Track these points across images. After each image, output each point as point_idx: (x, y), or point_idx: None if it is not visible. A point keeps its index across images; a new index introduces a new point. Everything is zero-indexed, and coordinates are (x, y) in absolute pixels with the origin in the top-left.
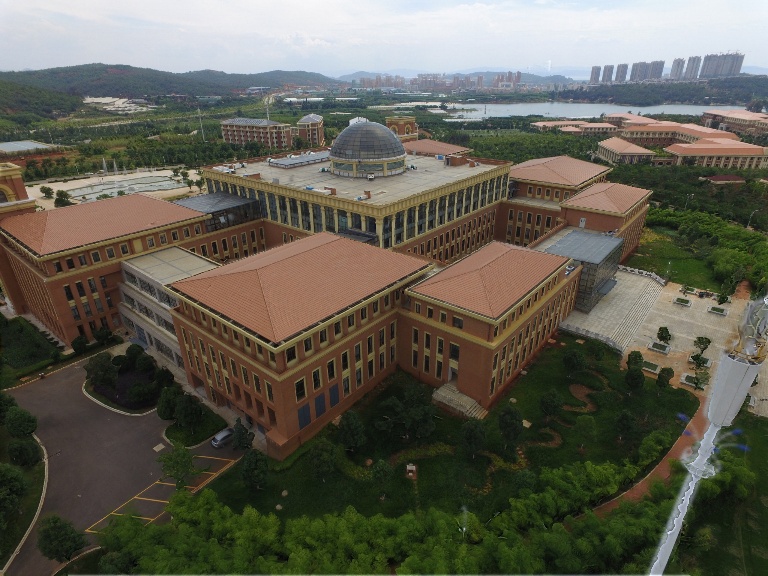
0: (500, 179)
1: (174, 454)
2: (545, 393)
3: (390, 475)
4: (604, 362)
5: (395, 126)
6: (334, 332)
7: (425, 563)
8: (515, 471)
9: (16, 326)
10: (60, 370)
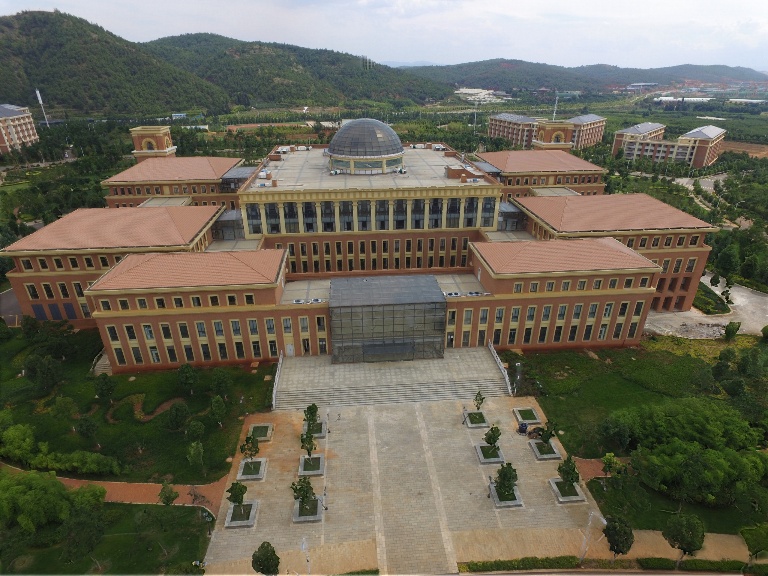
0: (477, 202)
1: None
2: None
3: None
4: (243, 403)
5: (542, 131)
6: (71, 264)
7: None
8: (34, 411)
9: None
10: None
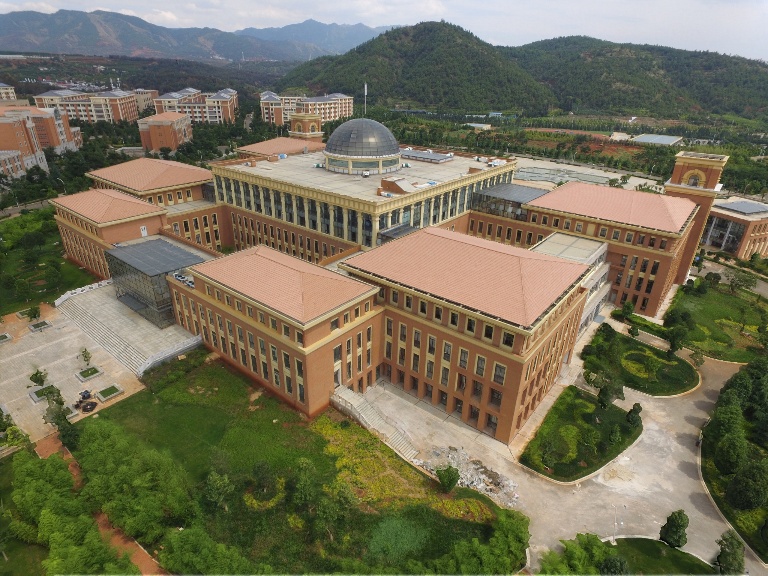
0: None
1: None
2: None
3: None
4: (56, 297)
5: None
6: None
7: None
8: None
9: None
10: None
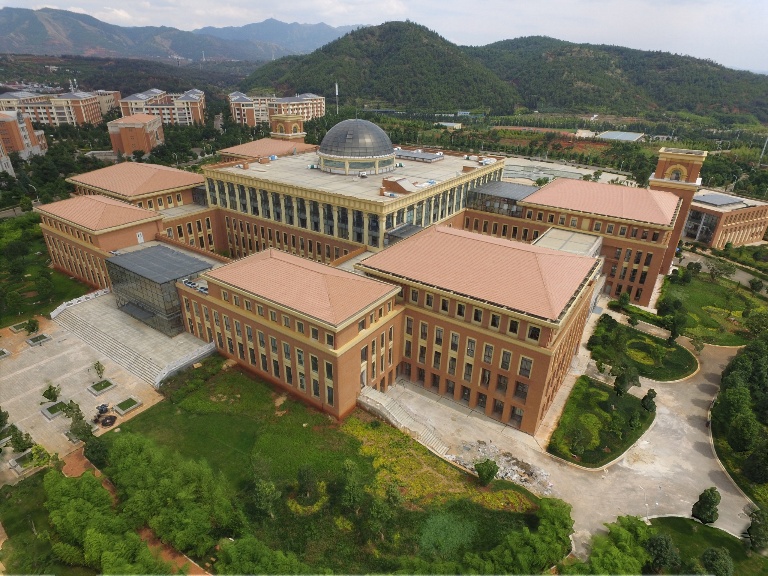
0: None
1: None
2: (19, 261)
3: None
4: (50, 309)
5: None
6: None
7: None
8: (2, 271)
9: None
10: None
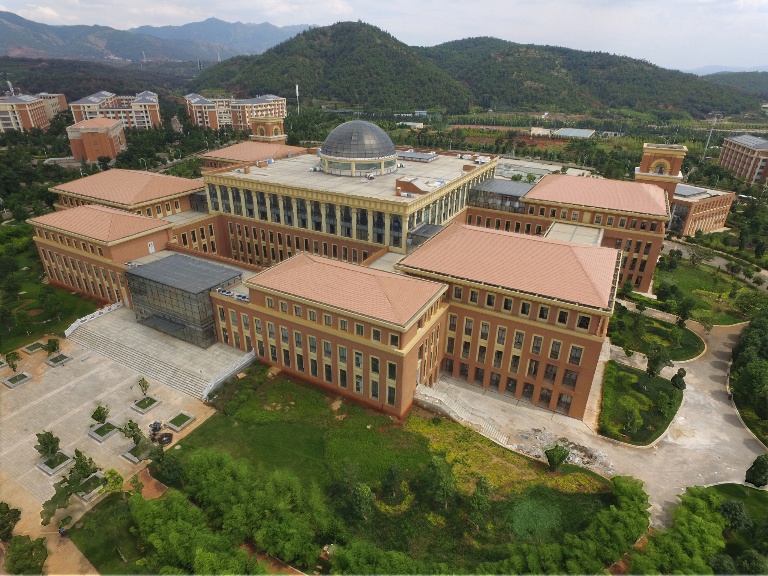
0: None
1: None
2: None
3: (6, 251)
4: (61, 327)
5: None
6: None
7: None
8: None
9: None
10: None
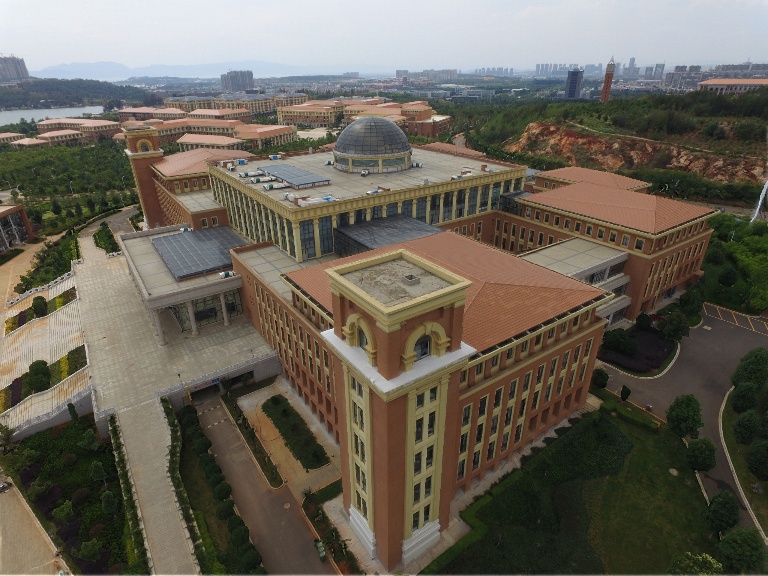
0: None
1: (767, 271)
2: None
3: None
4: None
5: (146, 140)
6: None
7: (763, 240)
8: None
9: (502, 503)
10: (630, 401)
